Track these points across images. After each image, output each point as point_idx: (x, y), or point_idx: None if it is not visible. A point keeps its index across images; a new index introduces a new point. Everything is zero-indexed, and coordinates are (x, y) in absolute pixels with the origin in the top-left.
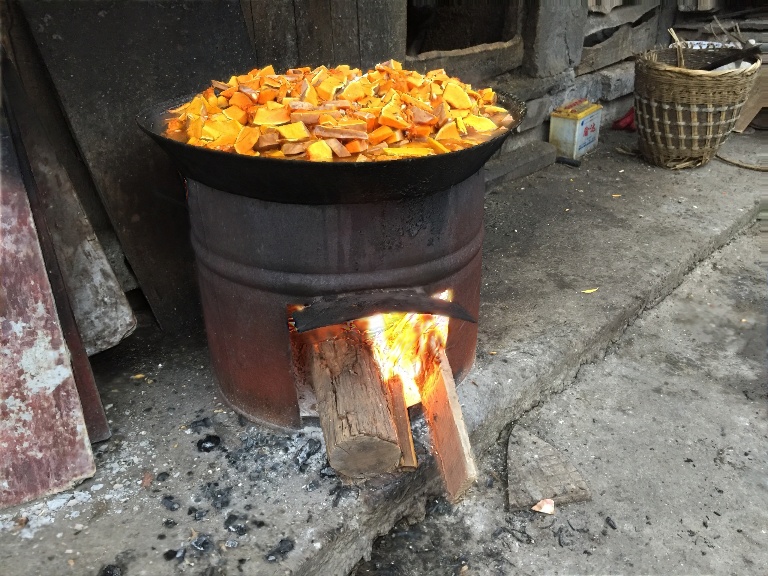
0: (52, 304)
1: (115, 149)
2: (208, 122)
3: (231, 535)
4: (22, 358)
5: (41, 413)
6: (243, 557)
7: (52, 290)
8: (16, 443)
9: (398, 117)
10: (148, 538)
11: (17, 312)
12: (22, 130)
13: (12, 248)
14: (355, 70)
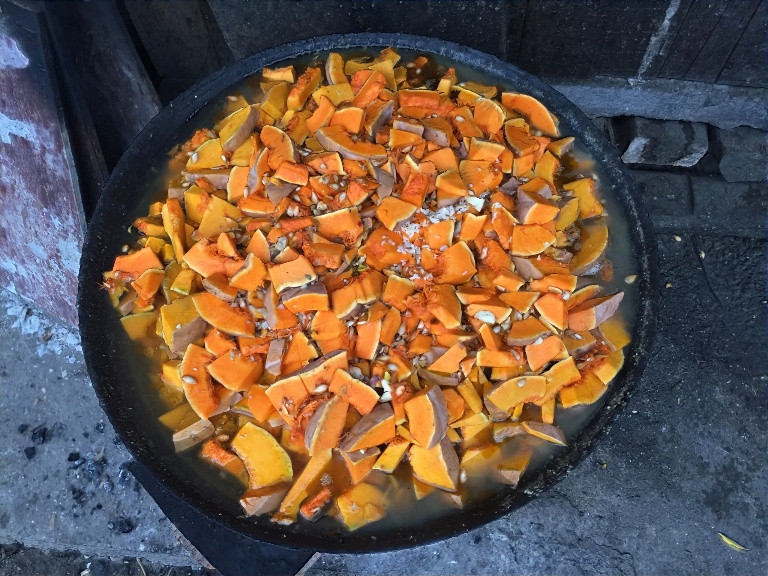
0: (79, 223)
1: (260, 37)
2: (167, 205)
3: (117, 477)
4: (59, 243)
5: (71, 282)
6: (103, 504)
7: (84, 209)
8: (56, 287)
9: (283, 408)
10: (80, 427)
11: (55, 212)
12: (104, 31)
13: (51, 165)
14: (460, 191)
